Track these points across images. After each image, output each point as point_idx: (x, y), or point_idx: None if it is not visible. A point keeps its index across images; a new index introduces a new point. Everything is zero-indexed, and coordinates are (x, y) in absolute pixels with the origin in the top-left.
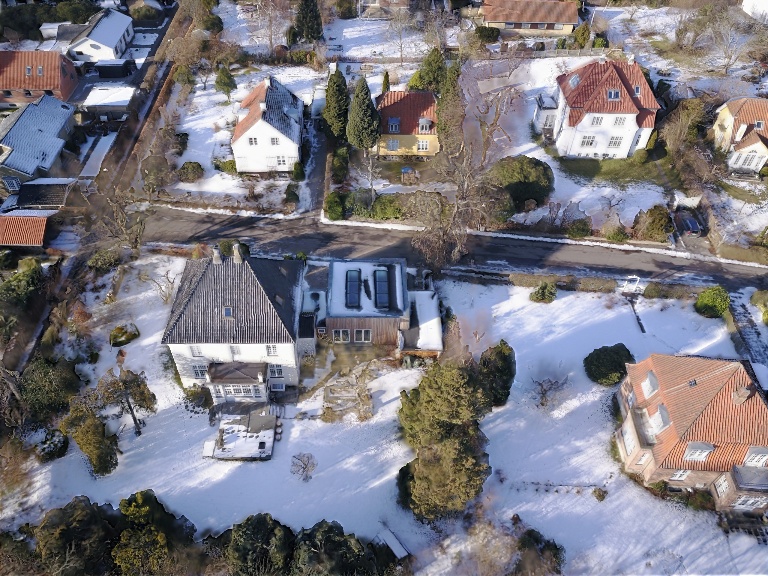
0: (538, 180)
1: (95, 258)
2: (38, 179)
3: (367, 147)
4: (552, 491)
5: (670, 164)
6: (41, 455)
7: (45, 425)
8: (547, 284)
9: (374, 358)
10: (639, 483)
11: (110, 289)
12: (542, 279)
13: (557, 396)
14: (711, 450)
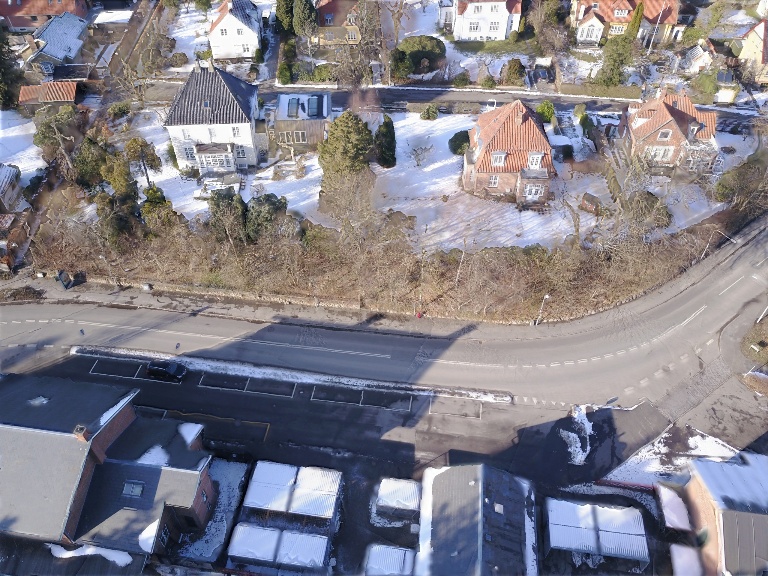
0: (432, 49)
1: (113, 107)
2: (67, 64)
3: (309, 37)
4: (416, 200)
5: (535, 41)
6: (89, 197)
7: (89, 187)
8: None
9: (309, 152)
10: (472, 194)
11: (125, 122)
12: (428, 105)
13: (425, 156)
14: (505, 155)
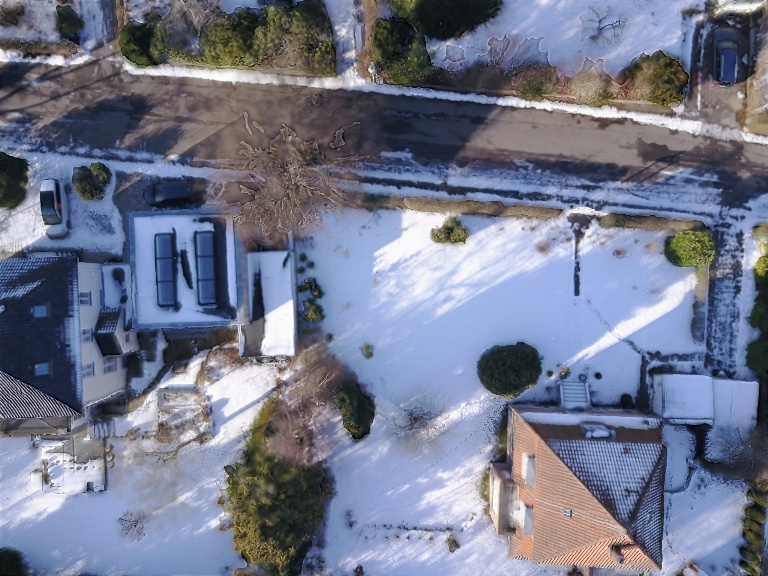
0: None
1: None
2: None
3: None
4: (403, 537)
5: None
6: None
7: None
8: (454, 225)
9: (215, 344)
10: None
11: None
12: (450, 209)
13: (428, 427)
14: None
